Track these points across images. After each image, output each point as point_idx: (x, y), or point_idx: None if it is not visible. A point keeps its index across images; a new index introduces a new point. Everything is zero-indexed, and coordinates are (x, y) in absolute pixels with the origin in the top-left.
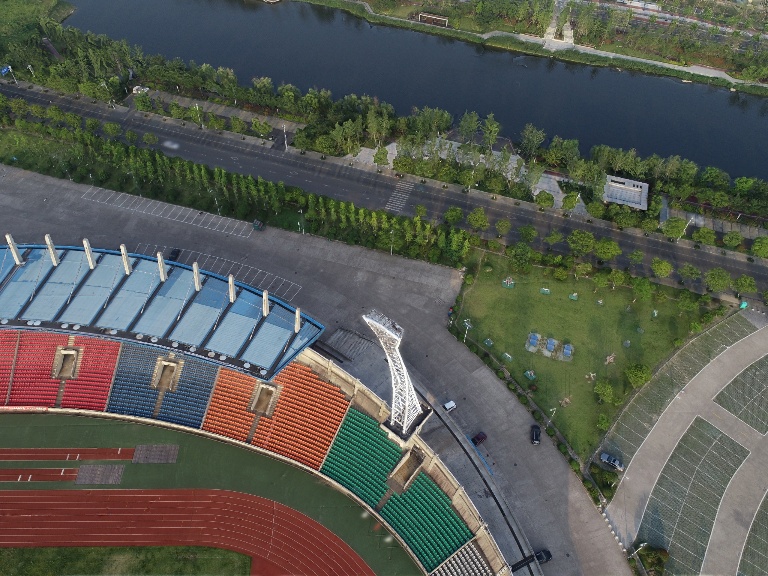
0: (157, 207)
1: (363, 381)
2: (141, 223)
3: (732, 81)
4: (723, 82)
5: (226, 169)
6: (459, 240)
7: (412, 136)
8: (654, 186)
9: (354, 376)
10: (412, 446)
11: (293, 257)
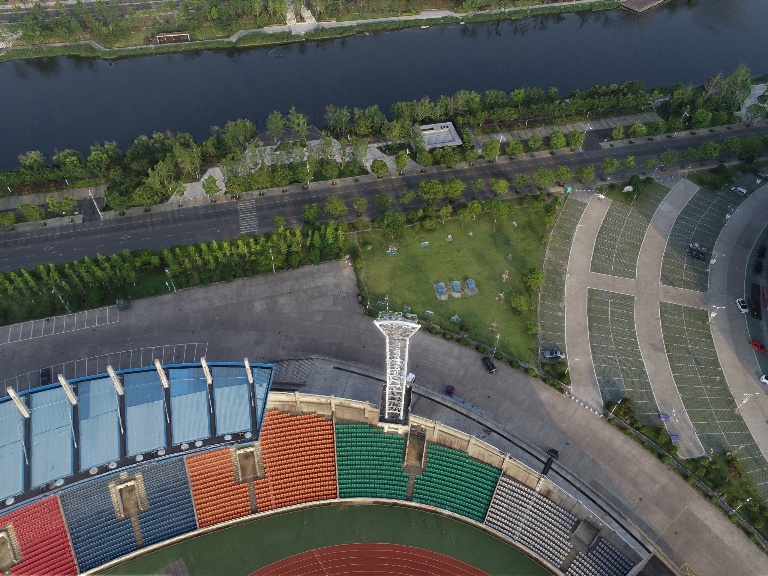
0: None
1: None
2: None
3: (458, 16)
4: (452, 19)
5: (45, 263)
6: (331, 232)
7: (231, 155)
8: (455, 122)
9: None
10: (409, 427)
11: (180, 319)
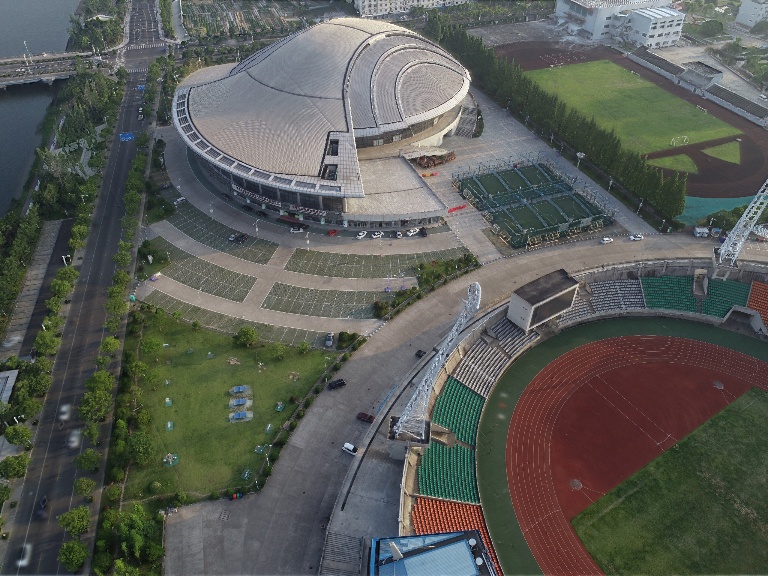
0: None
1: (379, 515)
2: None
3: None
4: None
5: None
6: None
7: None
8: None
9: (379, 526)
10: None
11: None
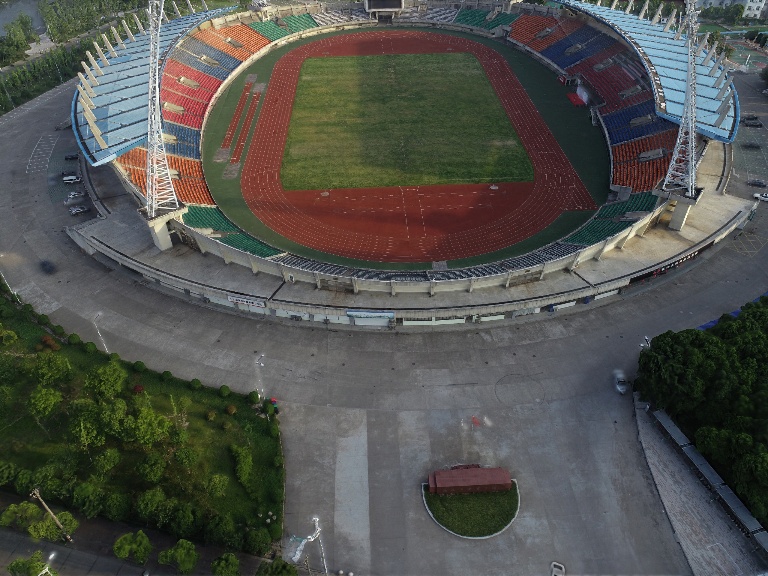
0: (35, 102)
1: None
2: (51, 104)
3: None
4: None
5: None
6: None
7: None
8: None
9: None
10: (269, 17)
11: None
